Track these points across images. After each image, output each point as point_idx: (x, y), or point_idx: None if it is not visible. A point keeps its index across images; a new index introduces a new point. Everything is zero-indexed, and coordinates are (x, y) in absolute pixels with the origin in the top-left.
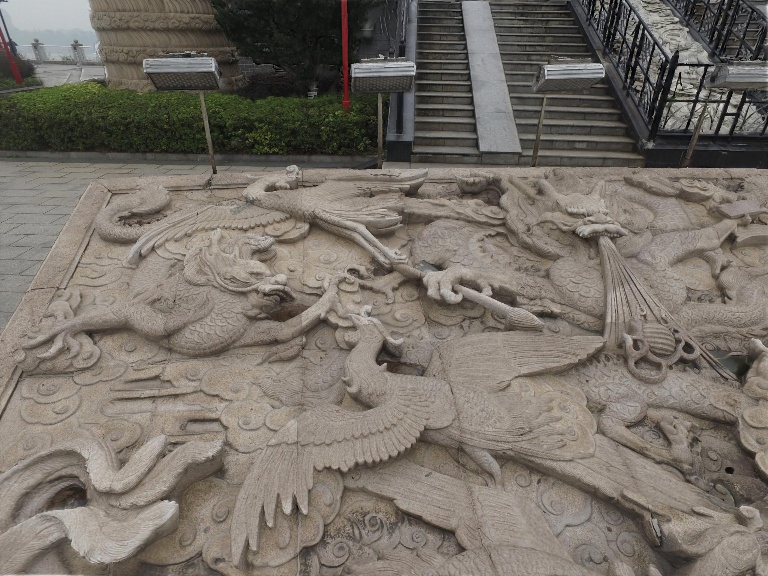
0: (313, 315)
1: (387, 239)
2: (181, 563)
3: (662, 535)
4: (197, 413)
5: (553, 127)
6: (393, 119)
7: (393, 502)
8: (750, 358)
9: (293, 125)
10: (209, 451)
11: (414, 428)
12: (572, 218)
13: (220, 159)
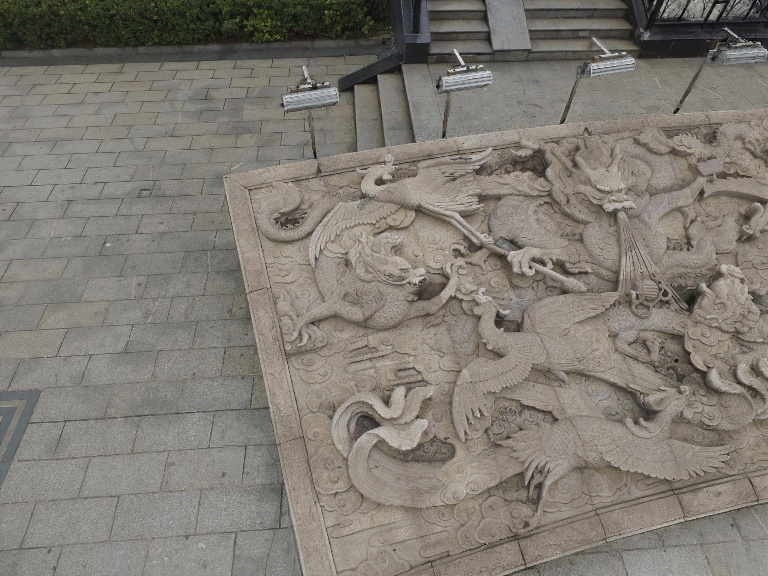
0: (448, 296)
1: (470, 217)
2: (428, 441)
3: (644, 402)
4: (400, 366)
5: (559, 11)
6: (407, 13)
7: (519, 401)
8: (697, 294)
9: (294, 9)
10: (430, 392)
11: (527, 366)
12: (599, 193)
13: (219, 49)
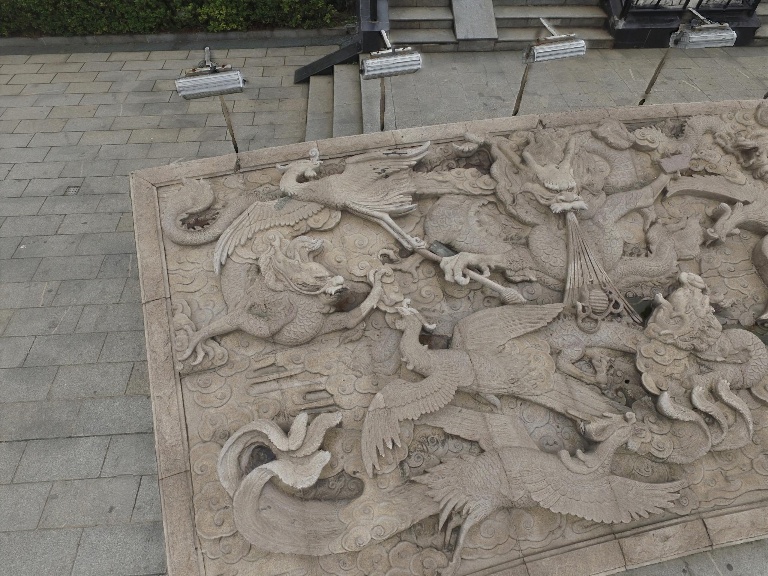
0: (369, 307)
1: (404, 218)
2: (334, 476)
3: (585, 430)
4: (310, 387)
5: None
6: None
7: (442, 429)
8: (653, 305)
9: None
10: (336, 420)
11: (452, 389)
12: (548, 192)
13: (172, 39)
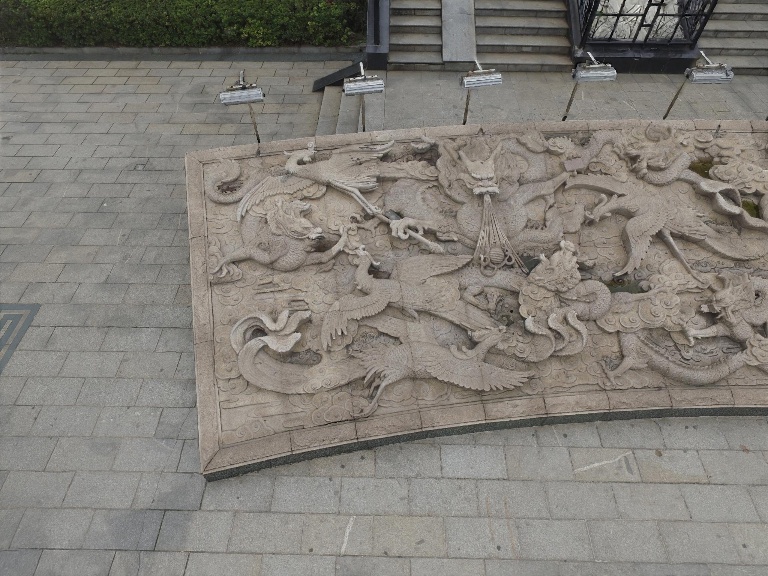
0: (337, 249)
1: (371, 193)
2: (304, 351)
3: (471, 336)
4: (294, 298)
5: (507, 29)
6: (371, 27)
7: (377, 329)
8: (538, 262)
9: (282, 20)
10: (307, 315)
11: (384, 303)
12: (473, 180)
13: (220, 52)
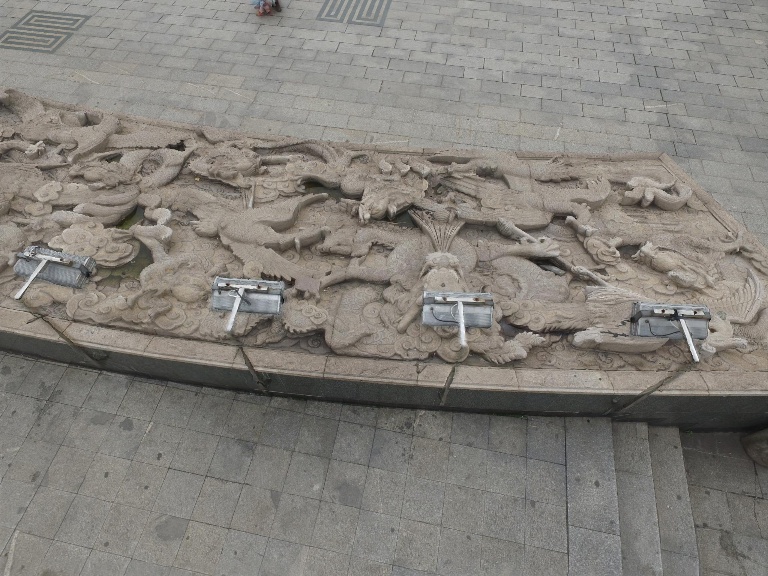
0: (616, 238)
1: None
2: None
3: None
4: None
5: None
6: None
7: None
8: None
9: None
10: (628, 192)
11: None
12: None
13: None
